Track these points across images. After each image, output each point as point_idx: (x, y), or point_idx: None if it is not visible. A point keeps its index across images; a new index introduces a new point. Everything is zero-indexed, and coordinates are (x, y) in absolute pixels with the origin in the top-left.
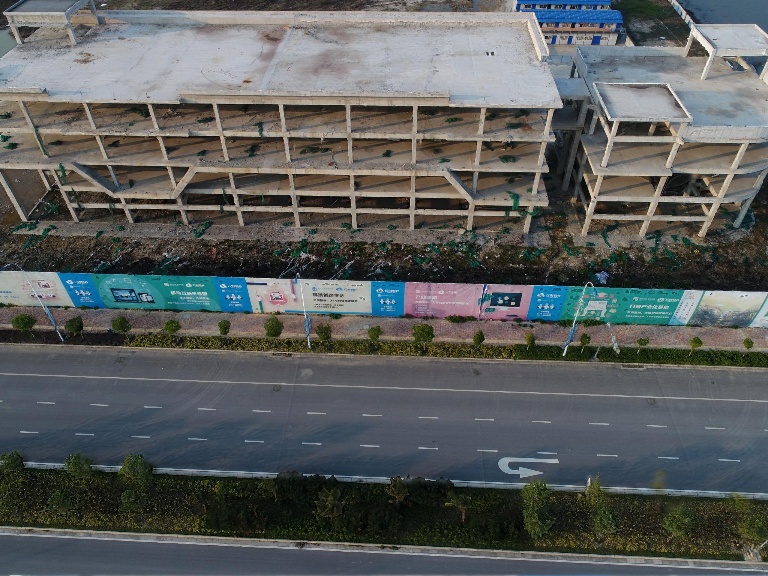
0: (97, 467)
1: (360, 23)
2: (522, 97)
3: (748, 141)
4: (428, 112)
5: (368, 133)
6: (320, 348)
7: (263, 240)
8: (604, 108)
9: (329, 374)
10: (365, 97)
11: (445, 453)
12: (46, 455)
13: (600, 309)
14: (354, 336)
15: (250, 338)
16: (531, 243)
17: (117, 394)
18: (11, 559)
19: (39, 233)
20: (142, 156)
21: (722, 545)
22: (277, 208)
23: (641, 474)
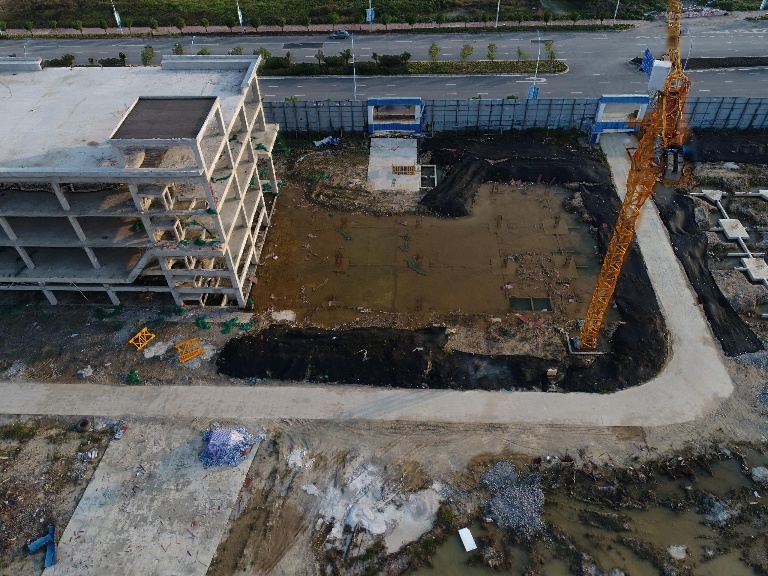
0: None
1: None
2: None
3: None
4: None
5: None
6: None
7: None
8: None
9: None
10: None
11: None
12: None
13: None
14: None
15: None
16: None
17: None
18: None
19: None
20: None
21: None
22: None
23: None
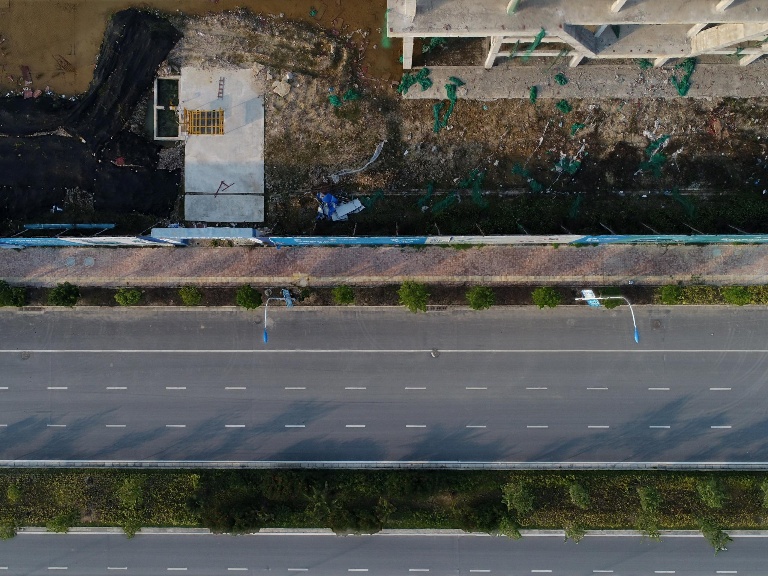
0: (690, 465)
1: None
2: None
3: None
4: None
5: None
6: None
7: None
8: None
9: None
10: None
11: None
12: (631, 453)
13: None
14: None
15: None
16: None
17: (673, 373)
18: (649, 558)
19: (443, 96)
20: (673, 0)
21: None
22: None
23: None
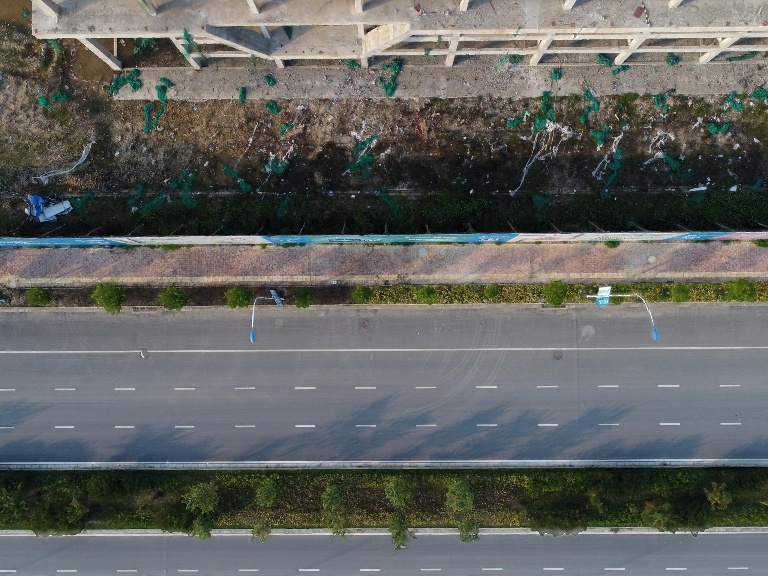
0: (395, 463)
1: None
2: None
3: None
4: None
5: None
6: None
7: (487, 97)
8: None
9: (614, 332)
10: None
11: (749, 429)
12: (337, 452)
13: None
14: (638, 274)
15: (512, 286)
16: None
17: (380, 373)
18: (354, 556)
19: (153, 97)
20: (314, 2)
21: None
22: (513, 51)
23: None
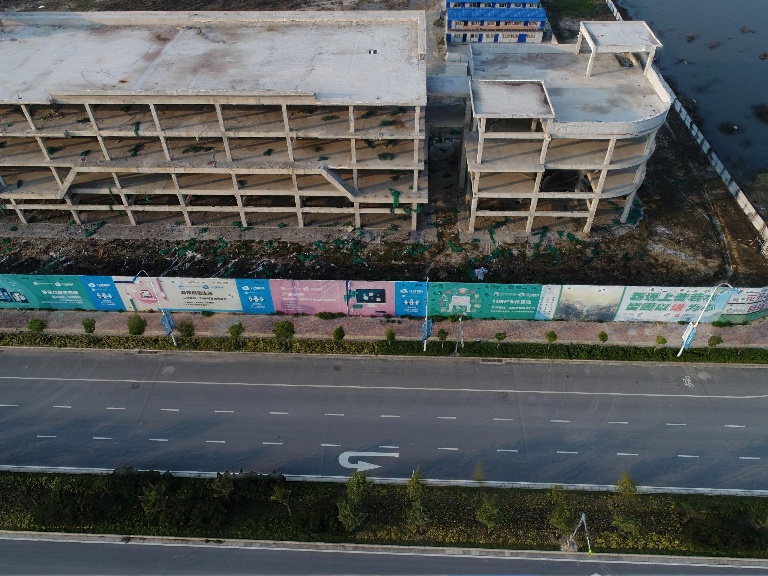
0: None
1: (253, 23)
2: (389, 95)
3: (615, 137)
4: (306, 110)
5: (242, 132)
6: (186, 345)
7: (152, 239)
8: (472, 105)
9: (190, 371)
10: (232, 96)
11: (288, 448)
12: None
13: (465, 304)
14: (222, 333)
15: (118, 336)
16: (417, 240)
17: None
18: None
19: None
20: (25, 156)
21: (541, 536)
22: (165, 207)
23: (477, 467)
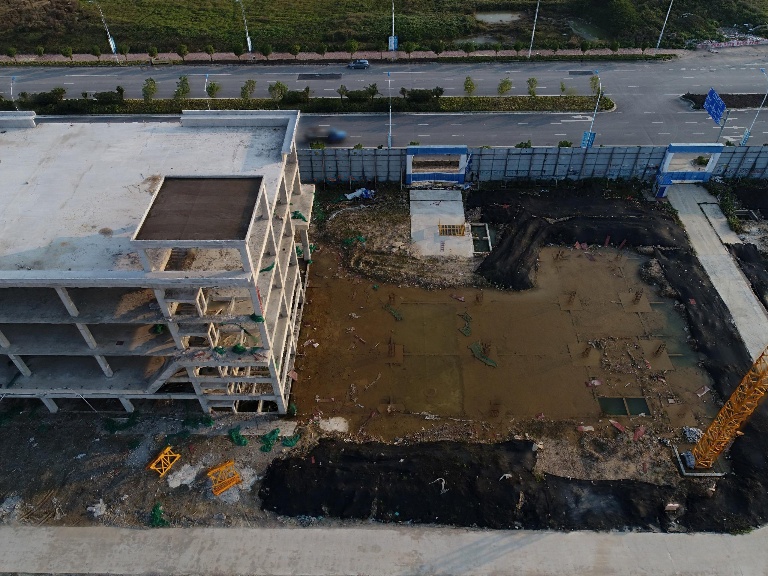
0: None
1: None
2: None
3: None
4: None
5: None
6: None
7: None
8: None
9: None
10: None
11: None
12: None
13: None
14: None
15: None
16: None
17: None
18: None
19: None
20: None
21: None
22: None
23: None
